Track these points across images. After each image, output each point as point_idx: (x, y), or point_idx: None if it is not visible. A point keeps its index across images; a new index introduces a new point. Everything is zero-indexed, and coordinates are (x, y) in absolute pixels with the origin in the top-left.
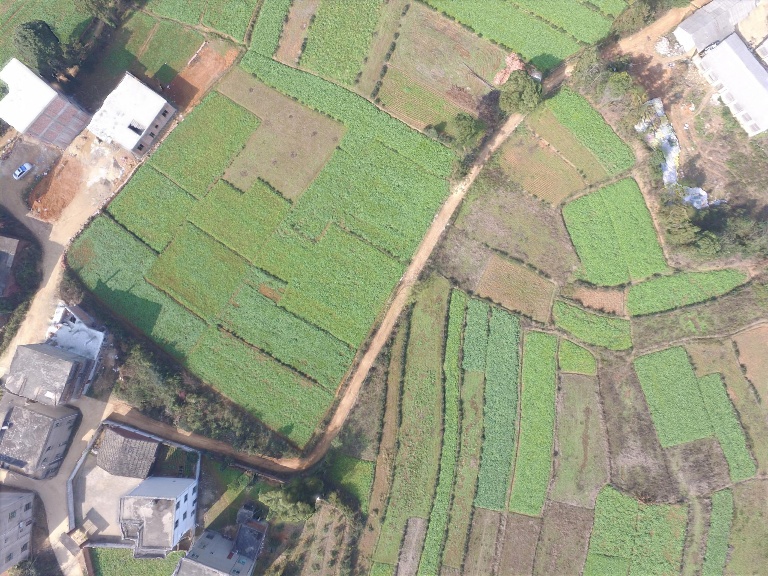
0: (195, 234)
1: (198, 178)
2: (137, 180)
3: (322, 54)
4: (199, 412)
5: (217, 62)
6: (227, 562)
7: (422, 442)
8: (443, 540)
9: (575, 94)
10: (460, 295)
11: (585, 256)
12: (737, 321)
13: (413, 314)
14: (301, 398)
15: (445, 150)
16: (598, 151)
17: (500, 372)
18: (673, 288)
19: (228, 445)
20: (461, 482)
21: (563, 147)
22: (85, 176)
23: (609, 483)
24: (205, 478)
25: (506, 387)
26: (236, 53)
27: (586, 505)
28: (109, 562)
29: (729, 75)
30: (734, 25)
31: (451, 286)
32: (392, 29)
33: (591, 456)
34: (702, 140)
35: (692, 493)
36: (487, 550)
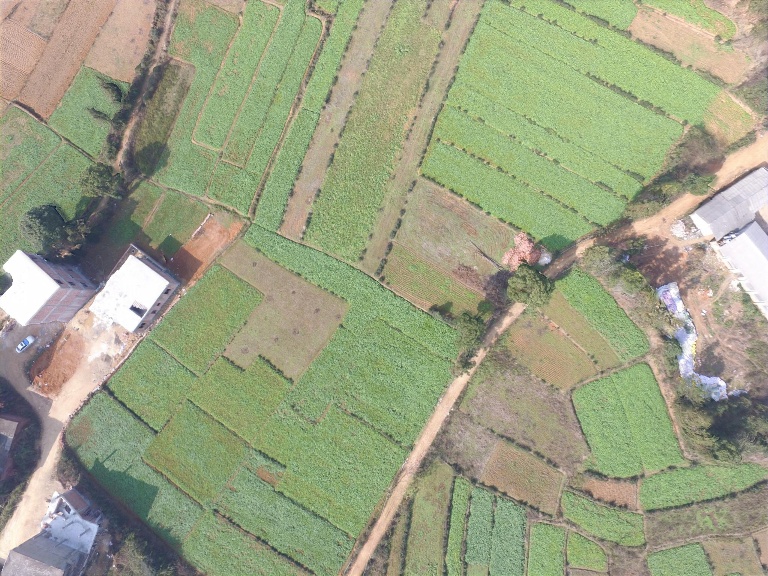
0: (194, 413)
1: (199, 354)
2: (138, 355)
3: (327, 229)
4: None
5: (221, 235)
6: None
7: None
8: None
9: (586, 276)
10: (464, 483)
11: (596, 445)
12: (758, 519)
13: (415, 502)
14: None
15: (450, 331)
16: (610, 336)
17: (505, 567)
18: (689, 482)
19: None
20: None
21: (573, 331)
22: (86, 351)
23: None
24: None
25: None
26: (240, 226)
27: None
28: None
29: (749, 267)
30: (755, 213)
31: (455, 474)
32: (398, 205)
33: None
34: (721, 327)
35: None
36: None
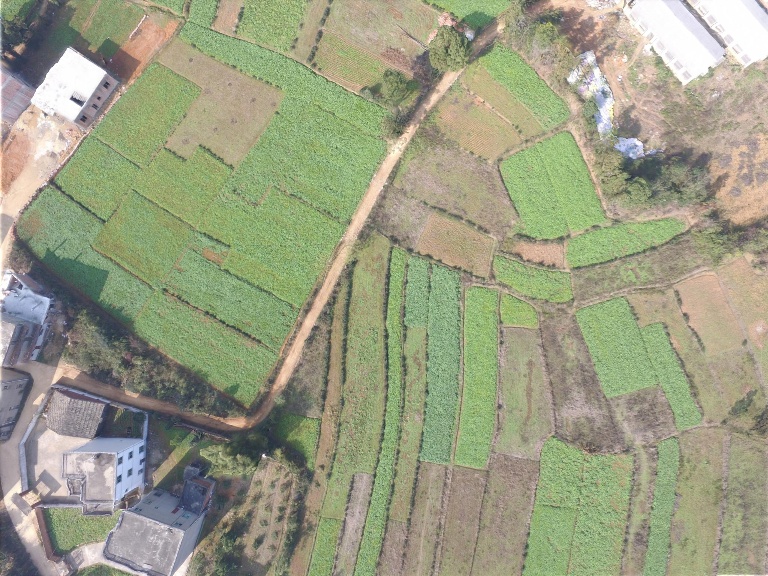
0: (139, 202)
1: (141, 148)
2: (82, 152)
3: (259, 22)
4: (145, 373)
5: (157, 34)
6: (171, 516)
7: (366, 398)
8: (389, 494)
9: (508, 51)
10: (400, 253)
11: (523, 210)
12: (678, 270)
13: (354, 273)
14: (246, 358)
15: (381, 111)
16: (533, 106)
17: (442, 328)
18: (612, 239)
19: (175, 406)
20: (406, 437)
21: (498, 103)
22: (32, 150)
23: (554, 434)
24: (153, 438)
25: (448, 342)
26: (176, 25)
27: (531, 457)
28: (62, 522)
29: (658, 24)
30: None
31: (391, 244)
32: None
33: (535, 408)
34: (636, 91)
35: (638, 442)
36: (433, 503)
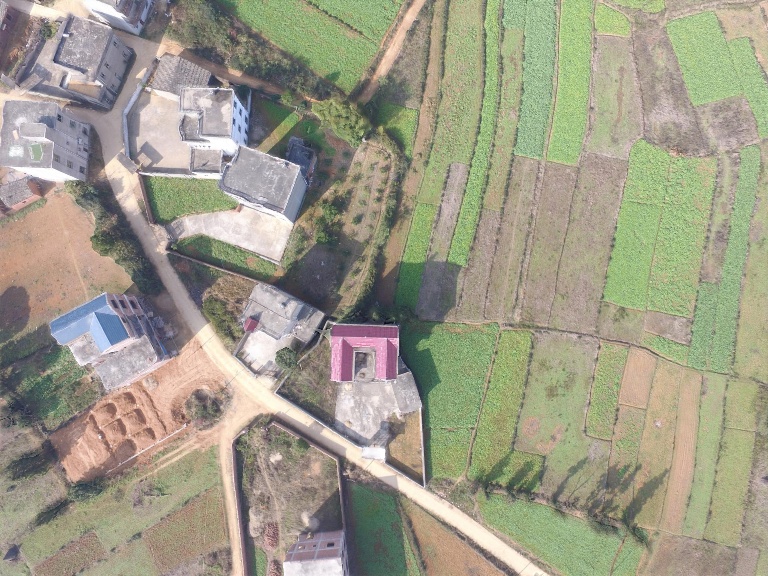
0: None
1: None
2: None
3: None
4: (250, 49)
5: None
6: None
7: (464, 93)
8: (484, 184)
9: None
10: None
11: None
12: None
13: None
14: (347, 48)
15: None
16: None
17: (539, 30)
18: None
19: (277, 88)
20: (501, 132)
21: None
22: None
23: (642, 137)
24: (256, 115)
25: (544, 44)
26: None
27: (620, 156)
28: (163, 192)
29: None
30: None
31: None
32: None
33: (625, 112)
34: None
35: (721, 148)
36: (526, 195)
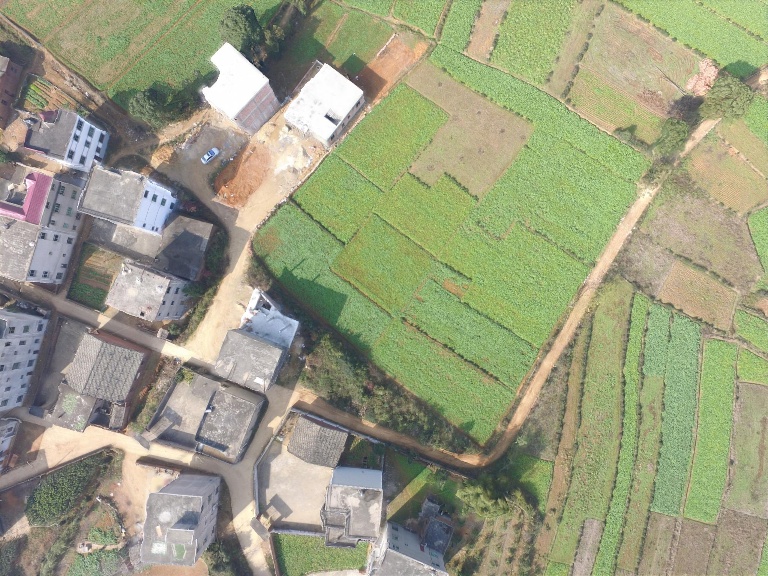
0: (381, 226)
1: (385, 170)
2: (324, 170)
3: (513, 51)
4: (387, 404)
5: (406, 55)
6: (424, 555)
7: (600, 444)
8: (619, 543)
9: (767, 103)
10: (642, 299)
11: None
12: None
13: (595, 316)
14: (483, 395)
15: (634, 153)
16: None
17: (680, 378)
18: None
19: (411, 438)
20: (637, 486)
21: (753, 156)
22: (273, 163)
23: None
24: (388, 470)
25: (685, 393)
26: (425, 46)
27: (760, 515)
28: (292, 548)
29: None
30: None
31: (635, 290)
32: (585, 29)
33: (767, 466)
34: None
35: None
36: (661, 555)
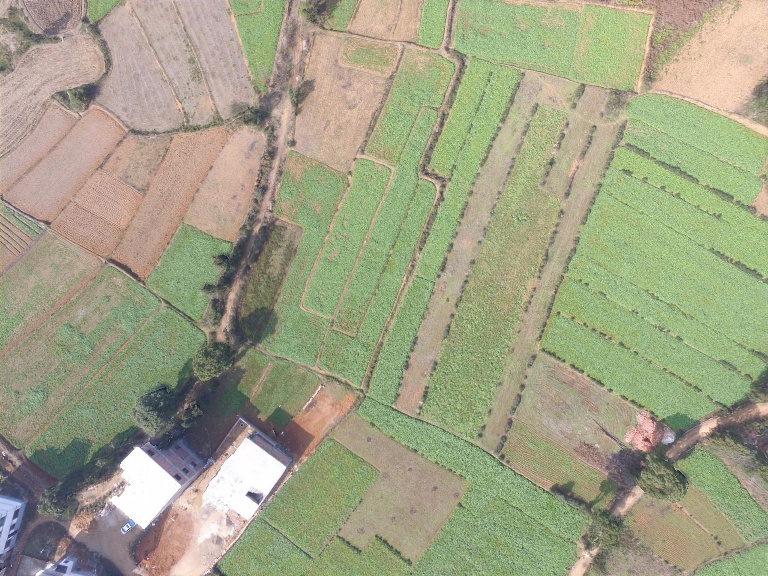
0: None
1: (313, 535)
2: (249, 536)
3: (444, 404)
4: None
5: (333, 408)
6: None
7: None
8: None
9: (709, 455)
10: None
11: None
12: None
13: None
14: None
15: (572, 511)
16: (734, 517)
17: None
18: None
19: None
20: None
21: (696, 511)
22: (196, 531)
23: None
24: None
25: None
26: (353, 398)
27: None
28: None
29: None
30: None
31: None
32: (517, 380)
33: None
34: None
35: None
36: None
